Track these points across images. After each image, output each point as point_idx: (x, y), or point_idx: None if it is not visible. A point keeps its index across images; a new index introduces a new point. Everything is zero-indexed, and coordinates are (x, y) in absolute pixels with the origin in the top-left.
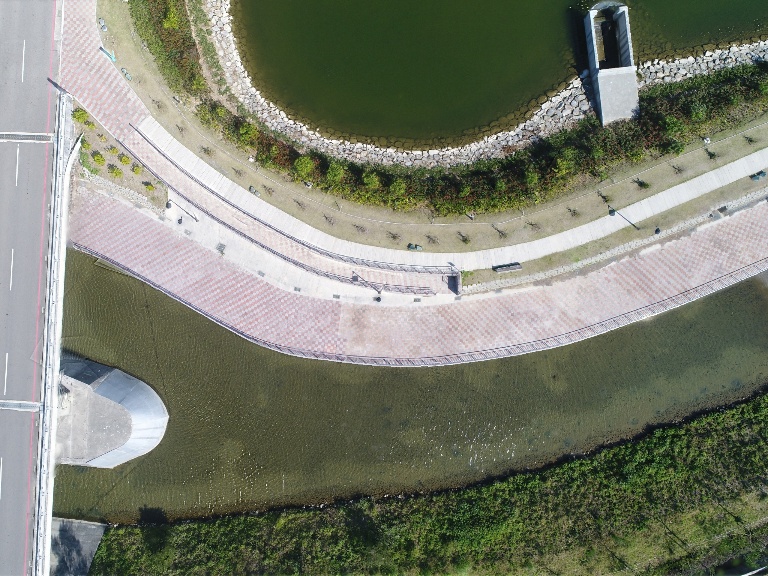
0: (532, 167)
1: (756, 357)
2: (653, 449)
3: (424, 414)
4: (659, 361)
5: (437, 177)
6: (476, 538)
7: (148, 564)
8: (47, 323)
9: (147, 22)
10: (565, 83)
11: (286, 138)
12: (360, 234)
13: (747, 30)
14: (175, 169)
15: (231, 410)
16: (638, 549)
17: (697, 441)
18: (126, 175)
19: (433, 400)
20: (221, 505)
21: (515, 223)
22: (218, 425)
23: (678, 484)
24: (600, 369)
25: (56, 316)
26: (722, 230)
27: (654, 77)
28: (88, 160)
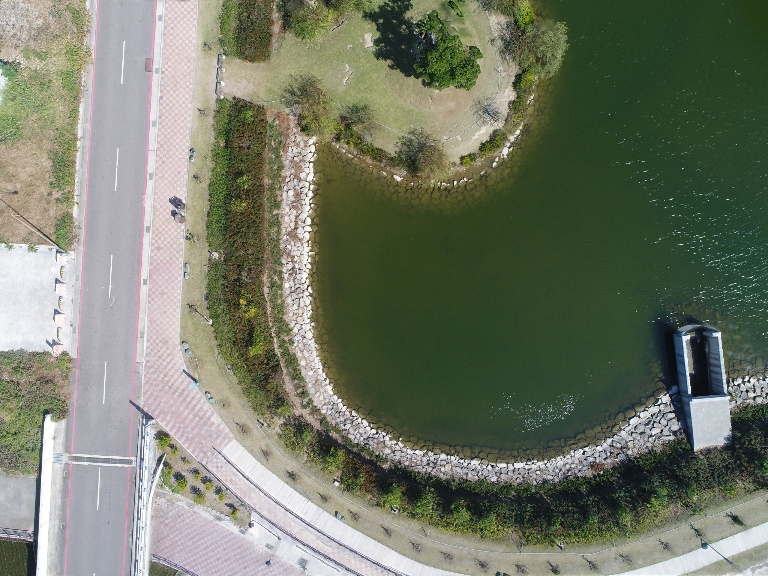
0: (622, 494)
1: None
2: None
3: None
4: None
5: (523, 495)
6: None
7: None
8: None
9: (232, 346)
10: (653, 398)
11: (370, 452)
12: (447, 561)
13: None
14: (259, 492)
15: None
16: None
17: None
18: (209, 497)
19: None
20: None
21: (606, 554)
22: None
23: None
24: None
25: None
26: None
27: (745, 397)
28: (170, 480)
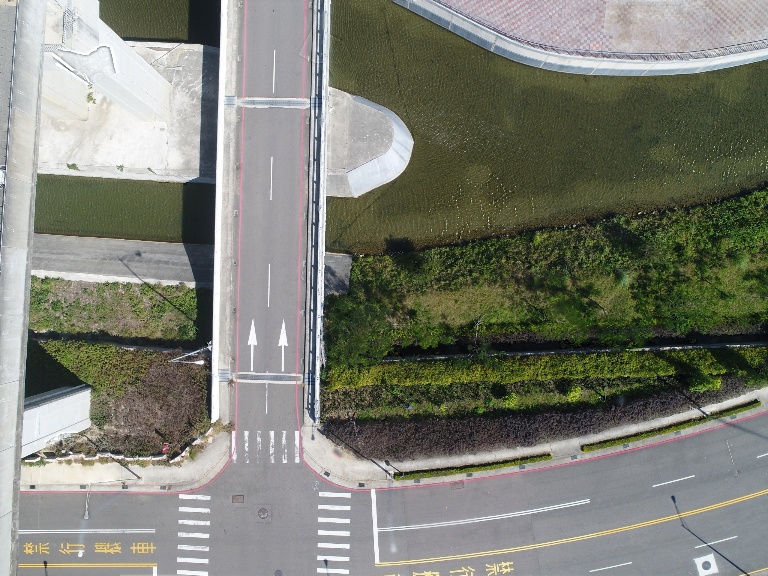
0: None
1: None
2: None
3: (675, 130)
4: None
5: None
6: (747, 236)
7: (408, 280)
8: (316, 17)
9: None
10: None
11: None
12: None
13: None
14: None
15: (477, 134)
16: None
17: None
18: None
19: (684, 115)
20: (469, 231)
21: None
22: (464, 150)
23: None
24: None
25: (328, 6)
26: None
27: None
28: None
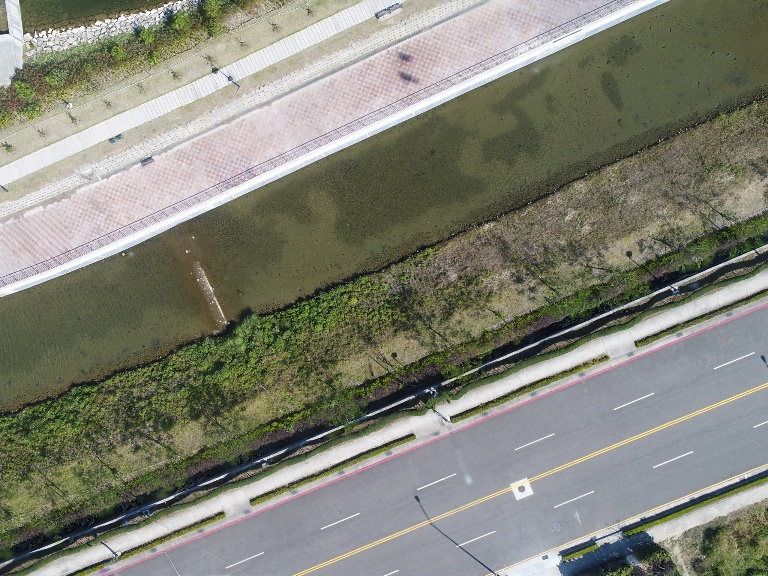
0: None
1: (173, 317)
2: (63, 406)
3: None
4: (84, 322)
5: None
6: None
7: None
8: None
9: None
10: None
11: None
12: None
13: (139, 0)
14: None
15: None
16: (22, 500)
17: (104, 398)
18: None
19: None
20: None
21: None
22: None
23: (70, 438)
24: (29, 330)
25: None
26: (100, 192)
27: (44, 46)
28: None
